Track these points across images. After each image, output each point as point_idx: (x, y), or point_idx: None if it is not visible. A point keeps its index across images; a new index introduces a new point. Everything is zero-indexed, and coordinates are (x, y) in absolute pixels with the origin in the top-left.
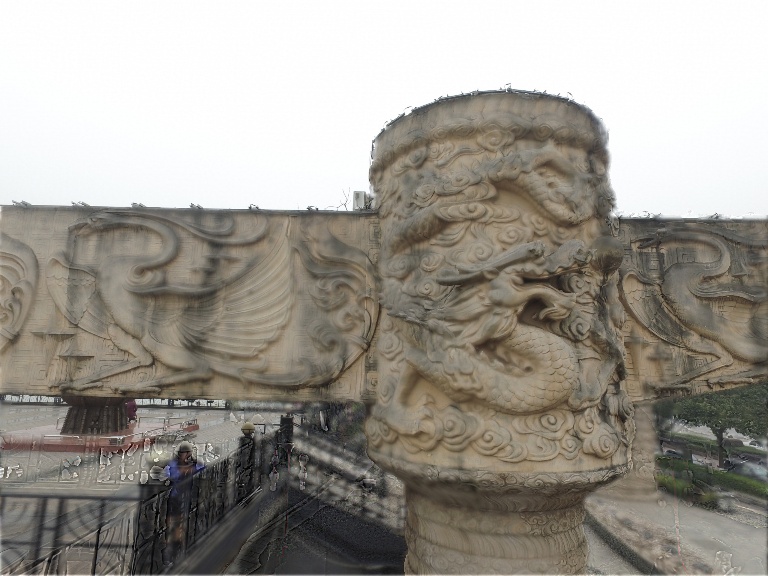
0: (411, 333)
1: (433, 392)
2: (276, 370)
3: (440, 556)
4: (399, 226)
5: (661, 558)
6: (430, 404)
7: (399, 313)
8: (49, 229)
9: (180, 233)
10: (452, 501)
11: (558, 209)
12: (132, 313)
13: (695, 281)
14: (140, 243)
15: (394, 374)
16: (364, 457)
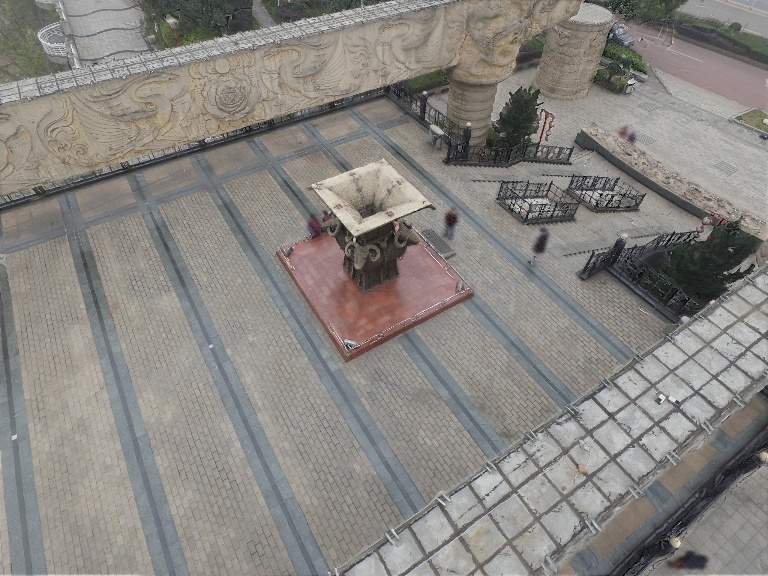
0: (483, 49)
1: (485, 64)
2: (438, 62)
3: (472, 99)
4: (483, 14)
5: (519, 89)
6: (483, 67)
7: (481, 44)
8: (372, 31)
9: (413, 22)
10: (478, 86)
11: (524, 7)
12: (403, 56)
13: (540, 7)
14: (401, 29)
15: (471, 58)
16: (261, 23)
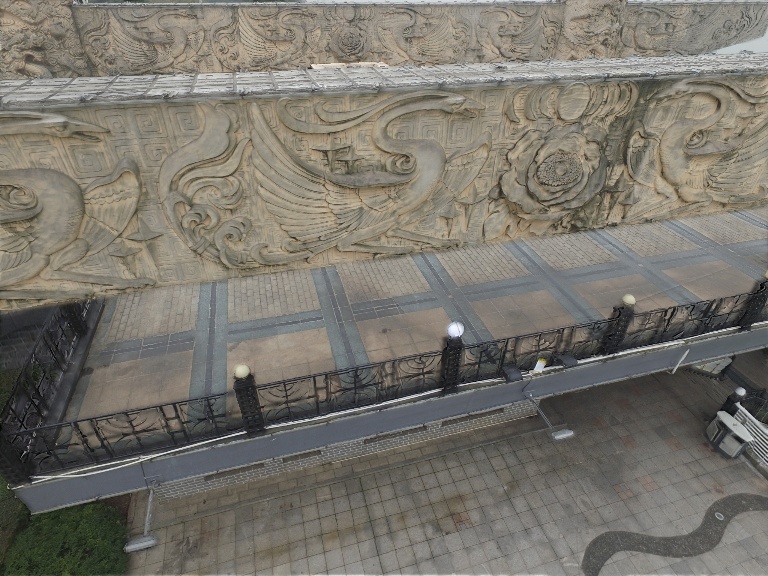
0: None
1: None
2: None
3: None
4: None
5: None
6: None
7: None
8: None
9: None
10: None
11: None
12: None
13: None
14: None
15: None
16: None
